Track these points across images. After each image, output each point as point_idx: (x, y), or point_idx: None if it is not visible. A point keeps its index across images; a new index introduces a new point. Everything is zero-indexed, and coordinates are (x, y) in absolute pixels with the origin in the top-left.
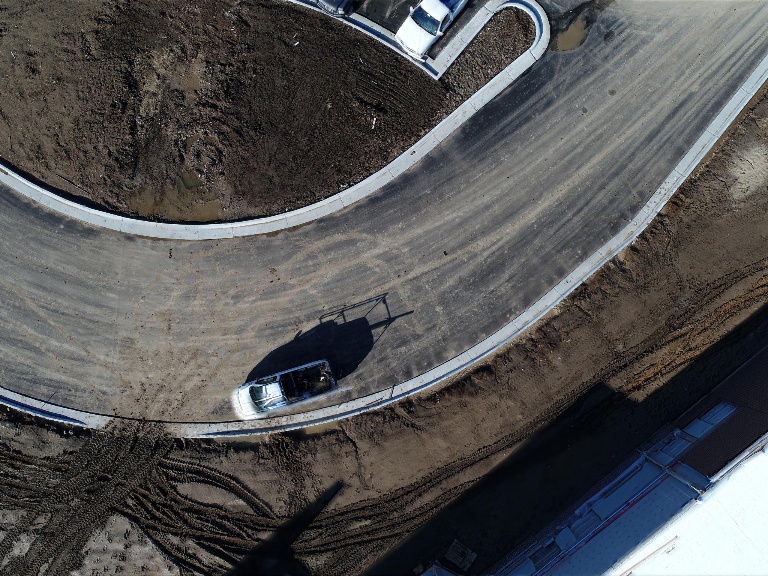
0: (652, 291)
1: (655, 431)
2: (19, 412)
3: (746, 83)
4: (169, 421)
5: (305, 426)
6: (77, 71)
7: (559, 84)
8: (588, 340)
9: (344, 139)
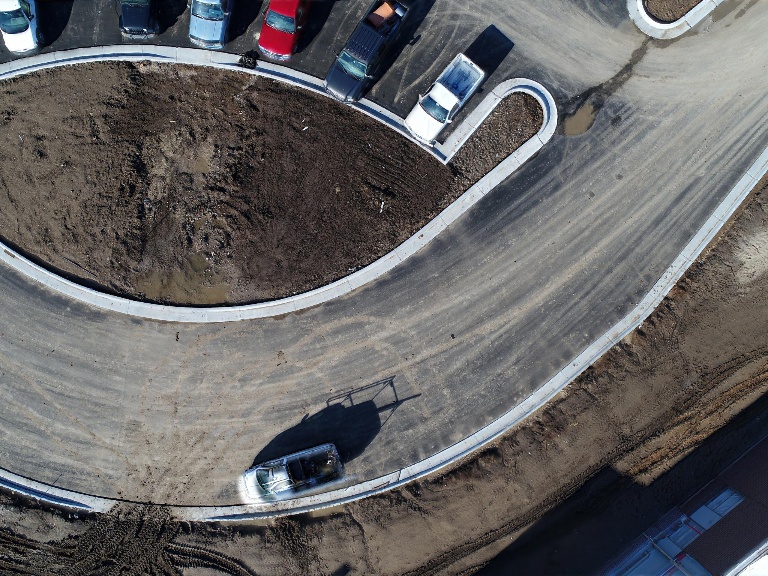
0: (659, 375)
1: (662, 515)
2: (24, 495)
3: (752, 168)
4: (175, 504)
5: (312, 510)
6: (85, 155)
7: (566, 168)
8: (595, 424)
9: (352, 223)
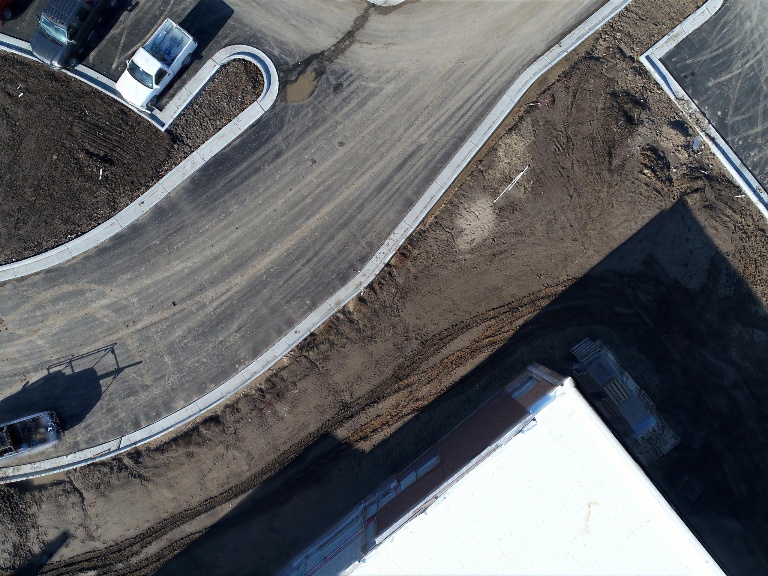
0: (379, 342)
1: (382, 482)
2: None
3: (474, 135)
4: None
5: (31, 477)
6: None
7: (288, 135)
8: (315, 391)
9: (71, 190)
